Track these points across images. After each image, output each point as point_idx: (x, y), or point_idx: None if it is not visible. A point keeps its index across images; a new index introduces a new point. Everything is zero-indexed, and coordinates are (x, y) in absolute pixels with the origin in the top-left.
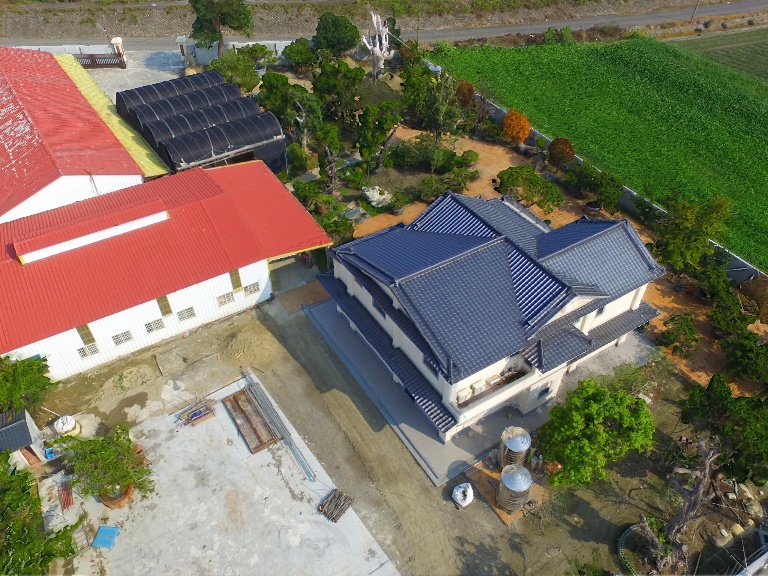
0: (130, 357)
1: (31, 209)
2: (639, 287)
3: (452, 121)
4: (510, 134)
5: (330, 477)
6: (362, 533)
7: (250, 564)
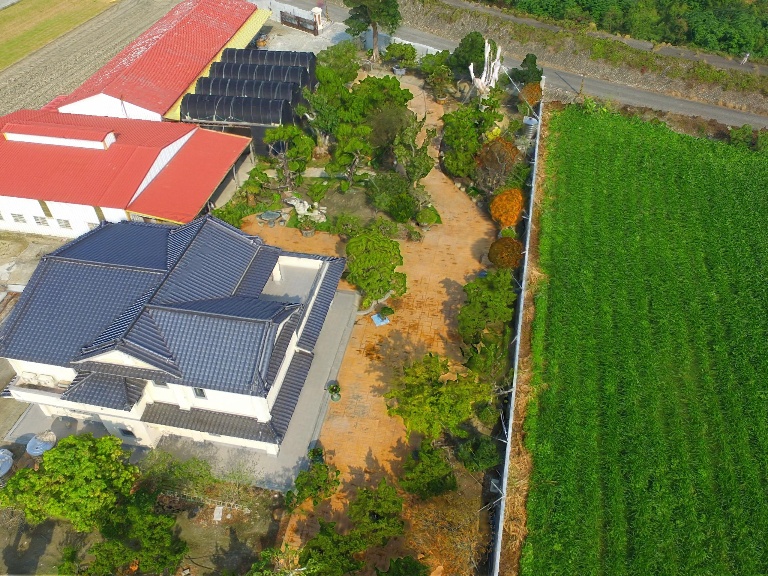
0: (24, 235)
1: (81, 110)
2: (222, 390)
3: (415, 171)
4: (493, 213)
5: None
6: None
7: None
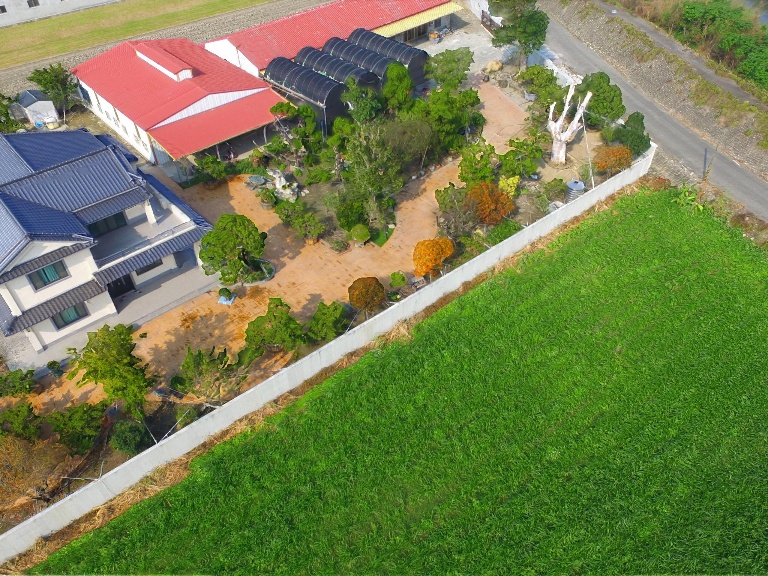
0: (110, 130)
1: None
2: None
3: None
4: None
5: None
6: None
7: None
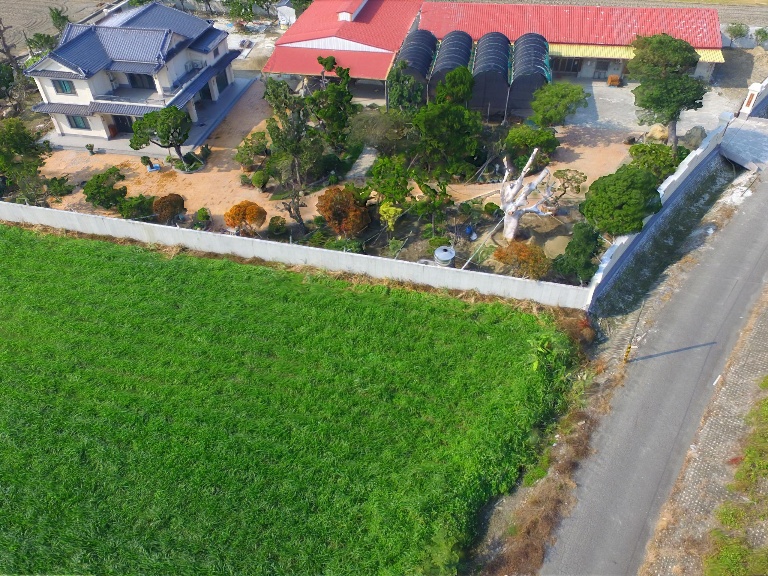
0: None
1: None
2: None
3: None
4: None
5: None
6: None
7: None
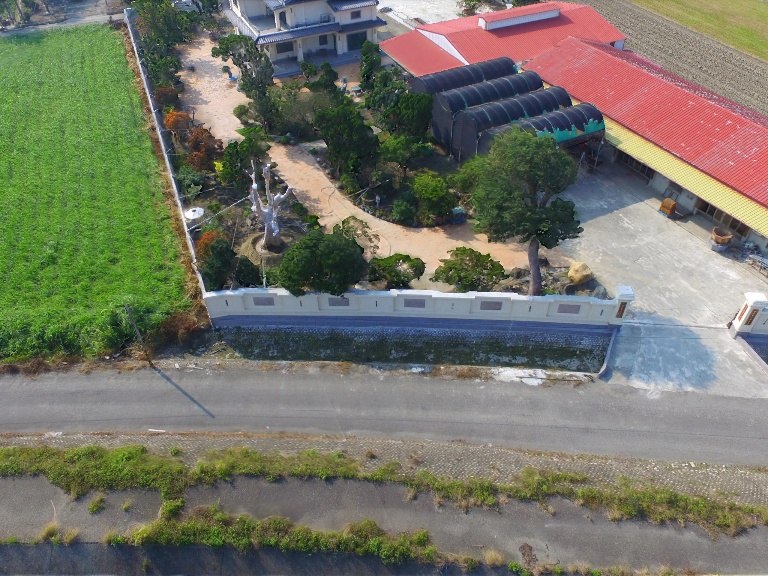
0: None
1: None
2: None
3: None
4: None
5: None
6: None
7: None
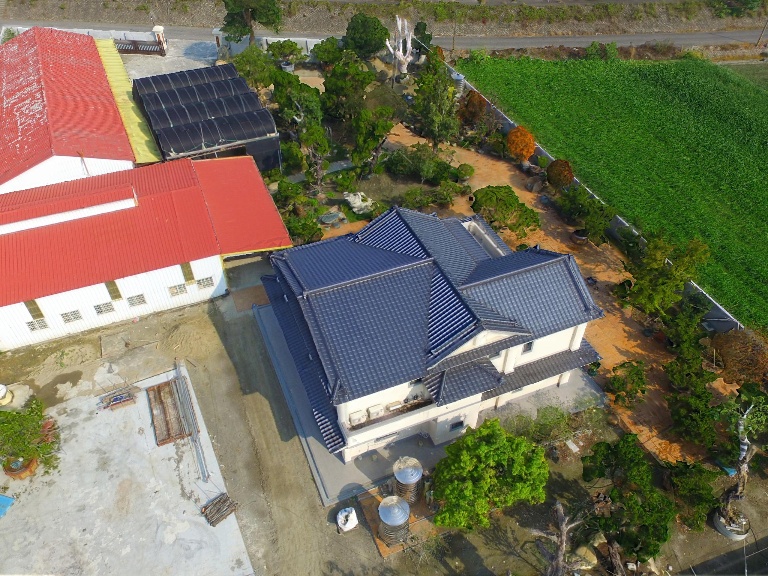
0: (79, 335)
1: (24, 184)
2: (569, 328)
3: (448, 133)
4: (513, 151)
5: (224, 480)
6: (236, 541)
7: (121, 554)
